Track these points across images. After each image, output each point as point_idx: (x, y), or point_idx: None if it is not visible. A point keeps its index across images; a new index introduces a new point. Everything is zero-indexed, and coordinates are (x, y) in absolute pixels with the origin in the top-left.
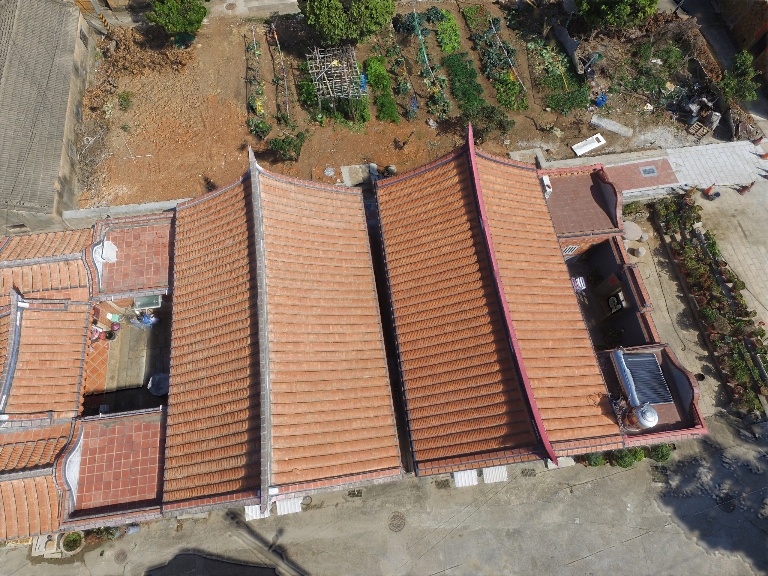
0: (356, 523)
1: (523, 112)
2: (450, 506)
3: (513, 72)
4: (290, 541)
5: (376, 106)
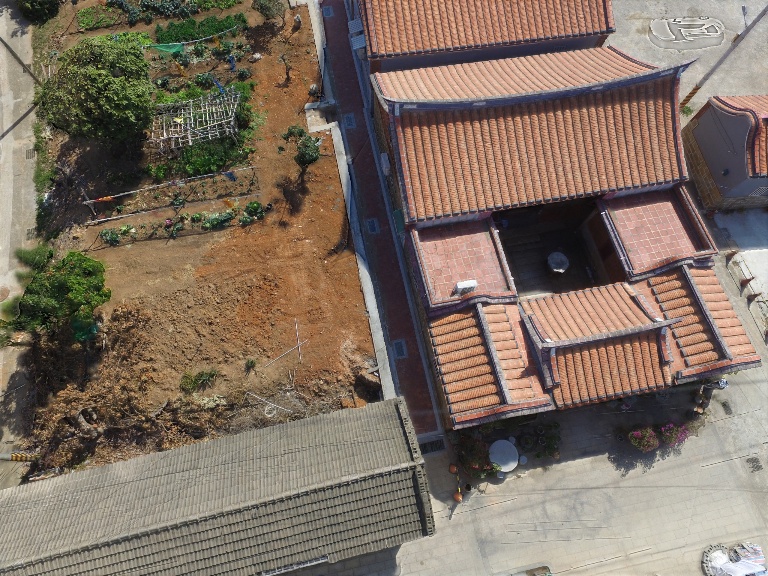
0: None
1: None
2: None
3: None
4: None
5: None
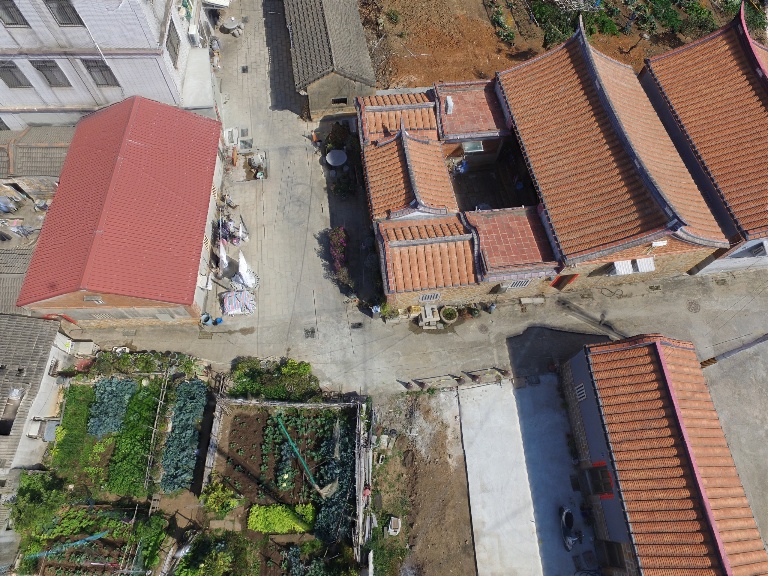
0: (662, 307)
1: None
2: (732, 296)
3: (698, 3)
4: (615, 318)
5: (597, 24)
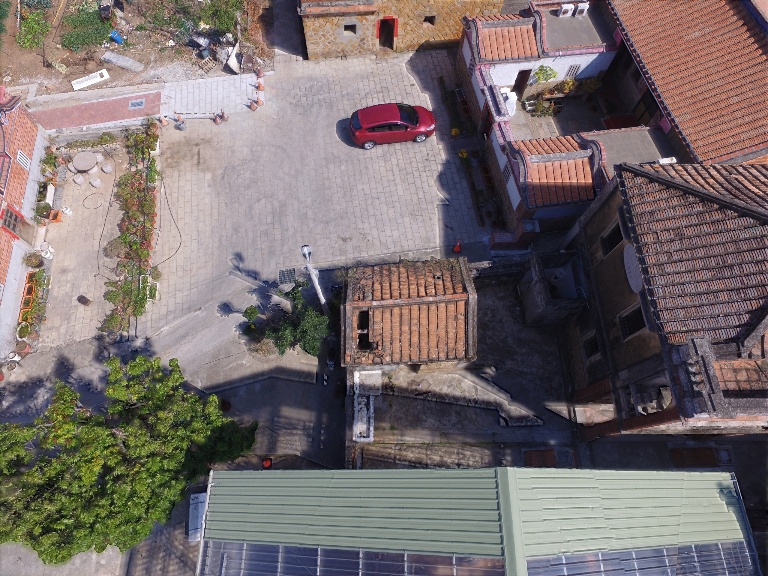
0: None
1: (36, 50)
2: None
3: (46, 12)
4: None
5: None
